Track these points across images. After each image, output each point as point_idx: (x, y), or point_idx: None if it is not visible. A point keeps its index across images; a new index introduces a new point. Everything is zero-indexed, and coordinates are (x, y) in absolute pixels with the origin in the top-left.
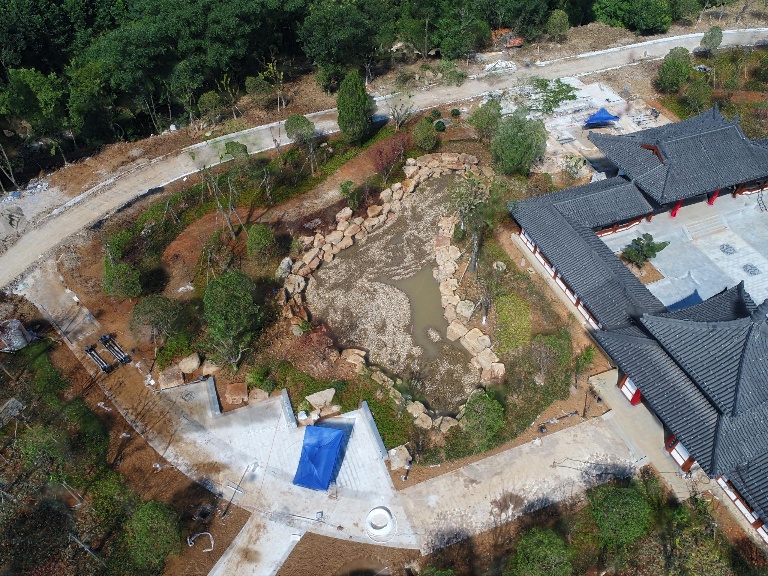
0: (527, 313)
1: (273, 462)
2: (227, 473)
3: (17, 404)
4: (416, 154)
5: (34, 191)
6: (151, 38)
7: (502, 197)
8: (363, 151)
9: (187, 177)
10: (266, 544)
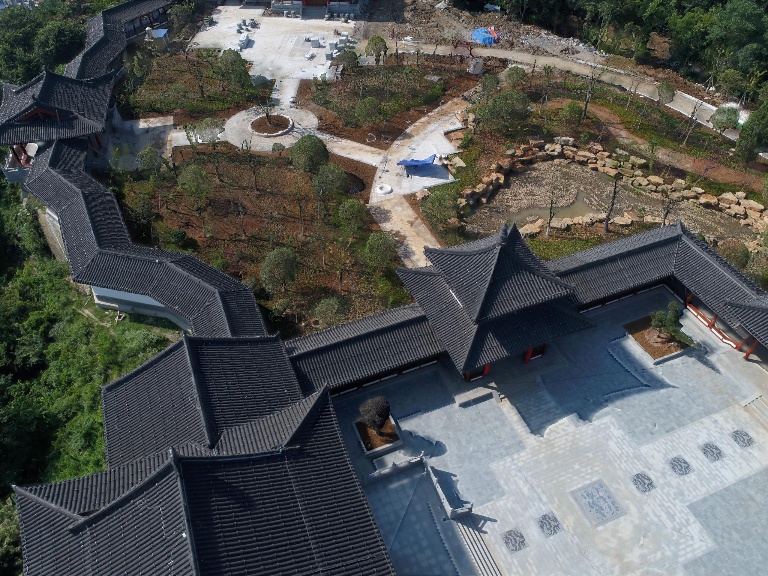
0: None
1: (416, 154)
2: (408, 141)
3: (437, 79)
4: (759, 200)
5: (598, 54)
6: (749, 13)
7: None
8: (740, 170)
9: (644, 97)
10: (371, 156)
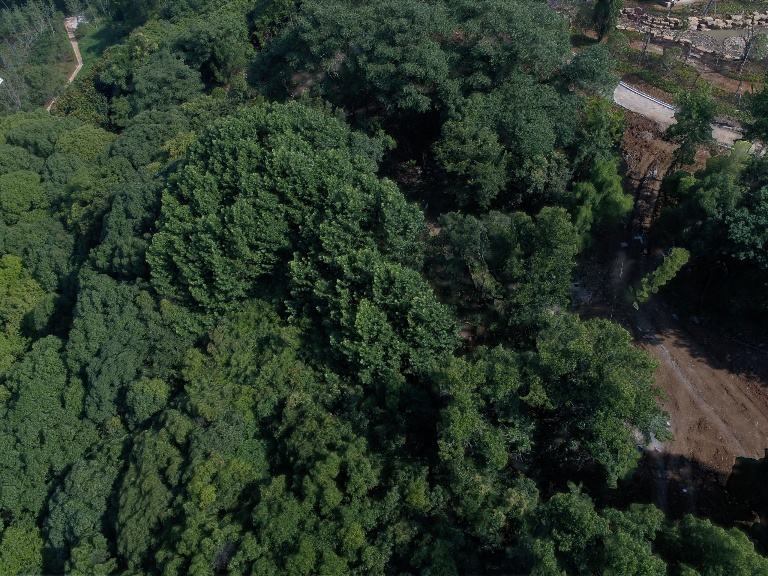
0: (728, 5)
1: None
2: None
3: None
4: None
5: None
6: None
7: (630, 7)
8: None
9: None
10: None
